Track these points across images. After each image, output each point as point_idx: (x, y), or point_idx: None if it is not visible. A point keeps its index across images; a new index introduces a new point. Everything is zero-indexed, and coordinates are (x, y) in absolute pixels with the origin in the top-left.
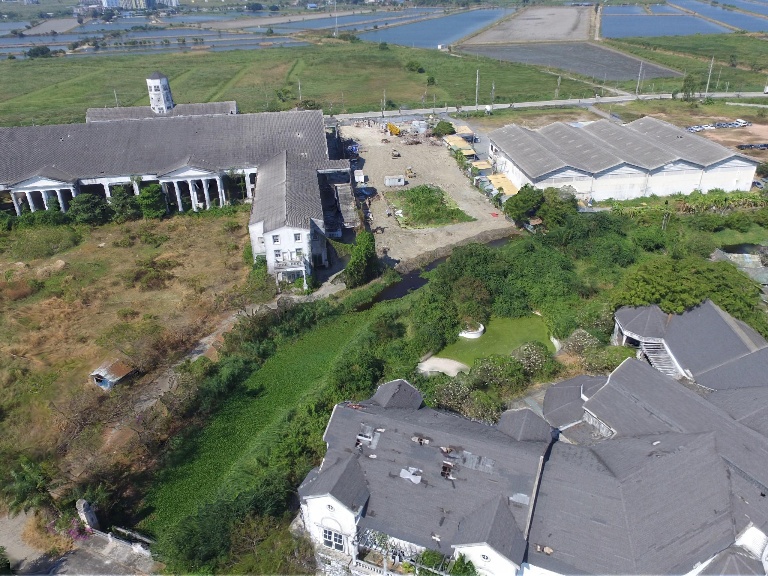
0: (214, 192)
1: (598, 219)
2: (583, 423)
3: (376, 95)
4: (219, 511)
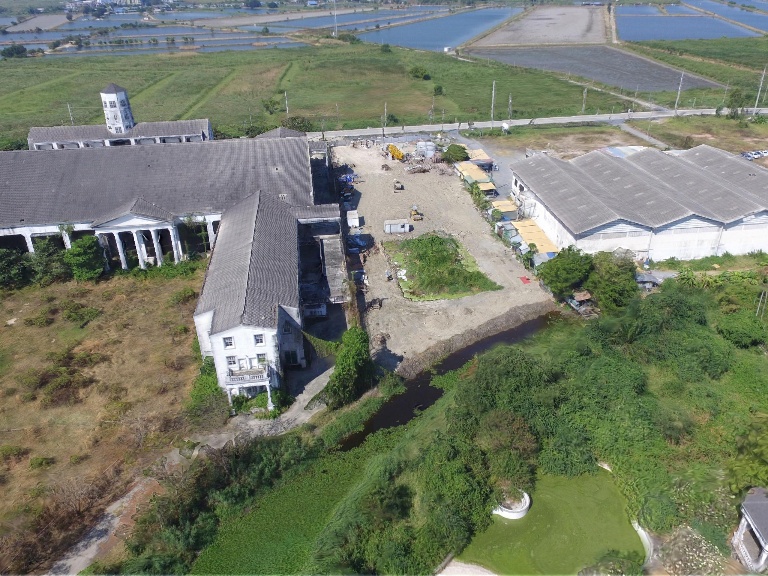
0: (168, 244)
1: (674, 305)
2: None
3: (376, 107)
4: None
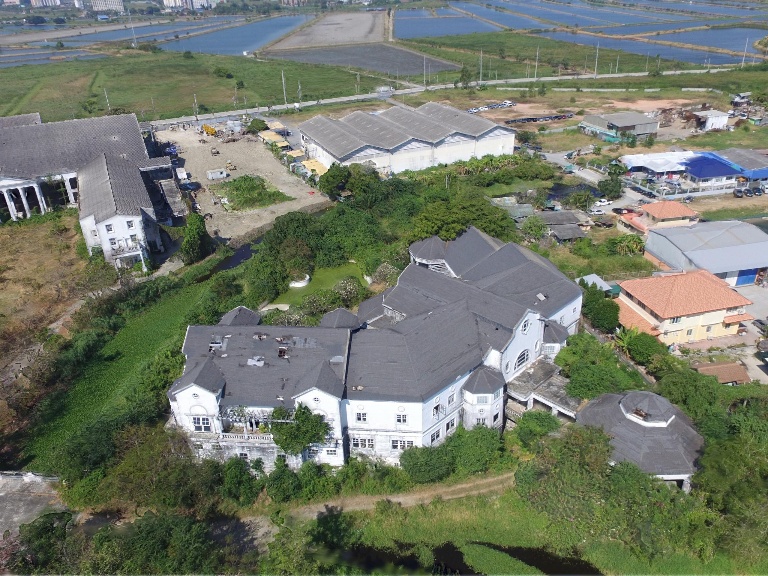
0: (33, 200)
1: (394, 184)
2: (384, 317)
3: (187, 101)
4: (101, 427)
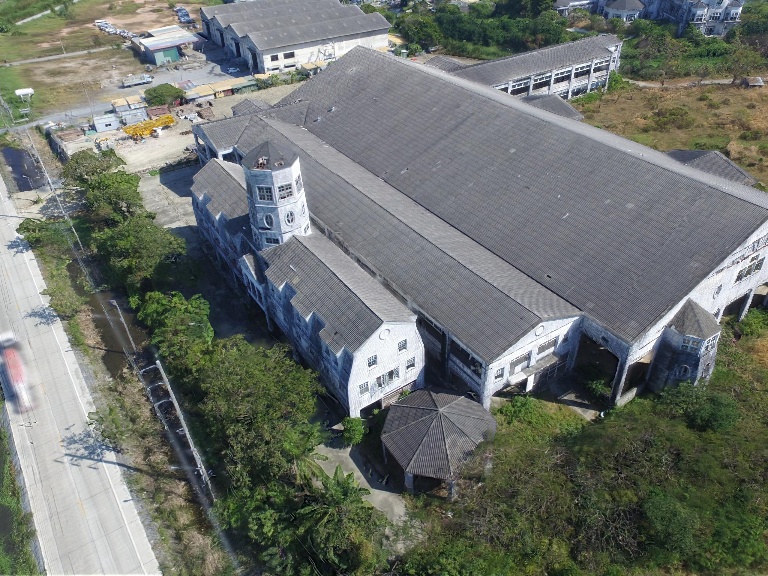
0: None
1: None
2: None
3: None
4: None
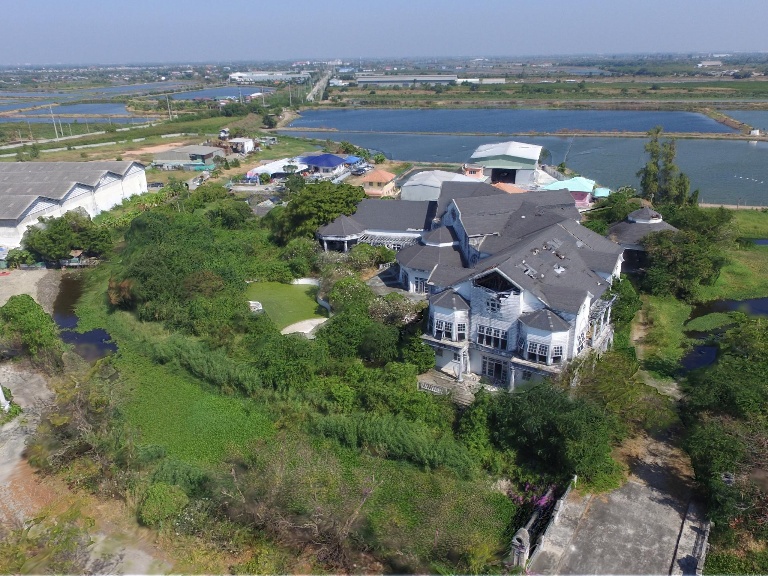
0: None
1: (156, 216)
2: None
3: None
4: None
